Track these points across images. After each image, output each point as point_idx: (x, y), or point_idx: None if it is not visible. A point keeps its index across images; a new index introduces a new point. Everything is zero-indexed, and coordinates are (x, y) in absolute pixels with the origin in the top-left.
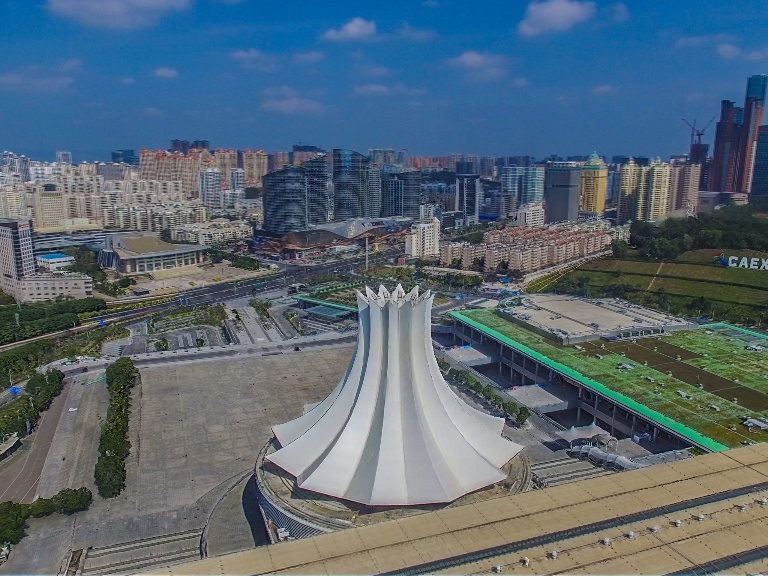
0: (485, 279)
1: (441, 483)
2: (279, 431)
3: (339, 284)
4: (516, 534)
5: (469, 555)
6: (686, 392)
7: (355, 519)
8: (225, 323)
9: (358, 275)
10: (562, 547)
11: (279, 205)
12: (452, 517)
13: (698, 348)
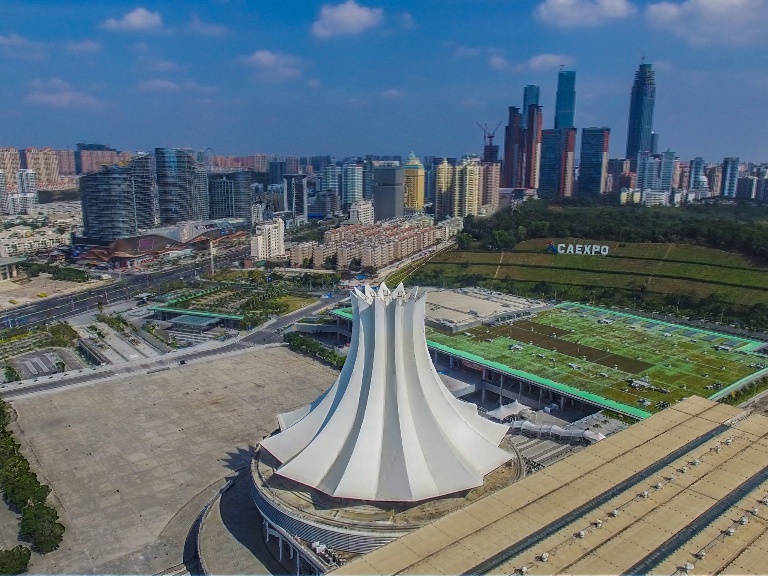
0: (341, 277)
1: (468, 470)
2: (270, 445)
3: (190, 291)
4: (571, 502)
5: (547, 528)
6: (575, 364)
7: (393, 519)
8: (82, 342)
9: (206, 281)
10: (614, 506)
11: (103, 209)
12: (508, 497)
13: (564, 325)
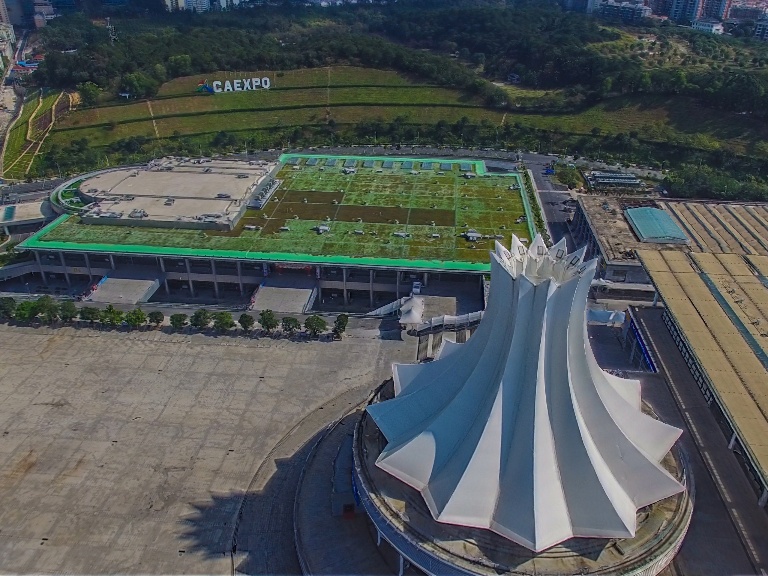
0: None
1: None
2: (454, 516)
3: None
4: None
5: None
6: None
7: None
8: None
9: None
10: None
11: None
12: (759, 437)
13: (324, 186)
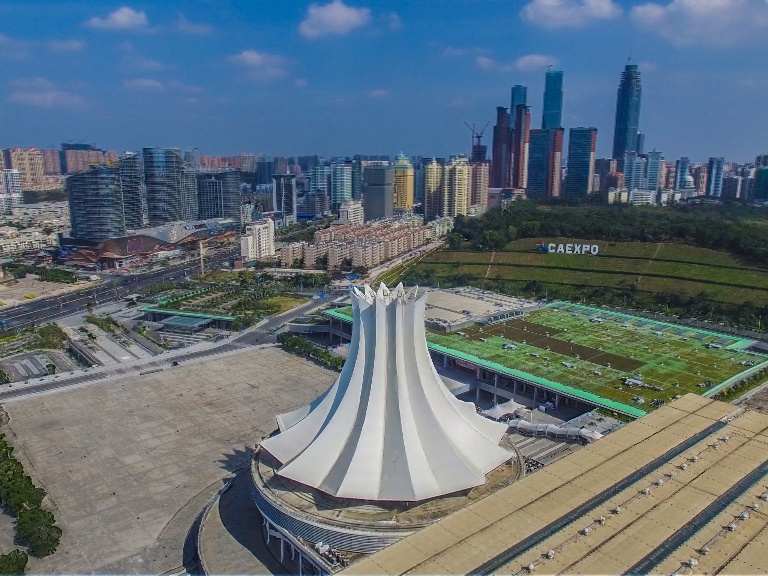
0: (332, 277)
1: (469, 468)
2: (270, 446)
3: (180, 292)
4: (574, 500)
5: (552, 525)
6: (569, 363)
7: (396, 518)
8: (72, 344)
9: (196, 281)
10: (617, 503)
11: (91, 210)
12: (511, 496)
13: (556, 324)
